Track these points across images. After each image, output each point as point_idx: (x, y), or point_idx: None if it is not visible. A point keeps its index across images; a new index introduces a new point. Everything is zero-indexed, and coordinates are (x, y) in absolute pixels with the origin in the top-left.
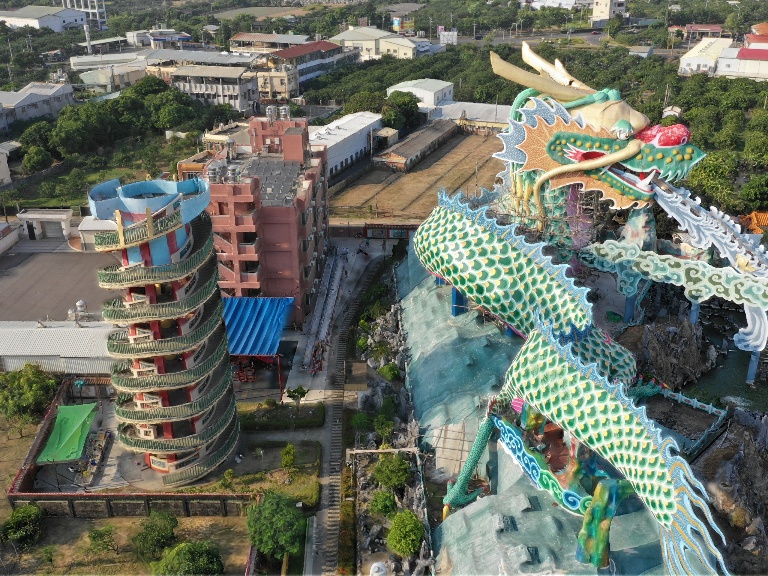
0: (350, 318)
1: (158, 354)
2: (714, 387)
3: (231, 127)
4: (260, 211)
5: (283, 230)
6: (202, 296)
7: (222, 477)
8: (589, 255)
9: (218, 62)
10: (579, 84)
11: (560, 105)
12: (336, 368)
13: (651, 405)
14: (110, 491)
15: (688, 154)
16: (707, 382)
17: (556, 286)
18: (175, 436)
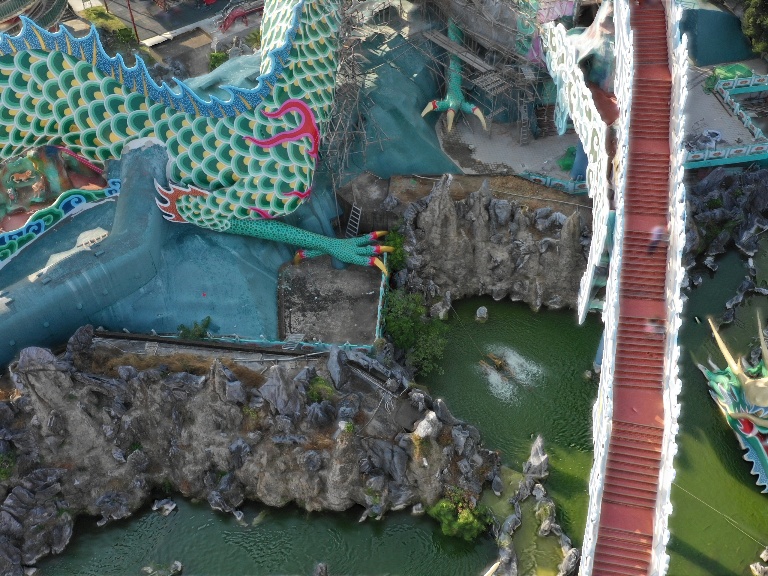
0: None
1: None
2: (557, 335)
3: None
4: None
5: None
6: None
7: None
8: (544, 38)
9: None
10: None
11: None
12: None
13: (347, 274)
14: None
15: None
16: (562, 323)
17: None
18: None
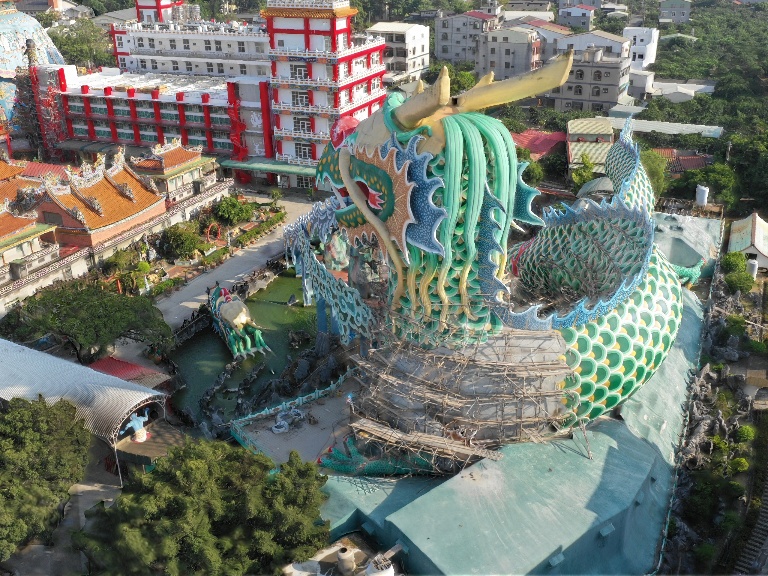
0: (759, 531)
1: None
2: None
3: None
4: None
5: None
6: None
7: None
8: None
9: None
10: None
11: None
12: None
13: None
14: None
15: None
16: None
17: None
18: None
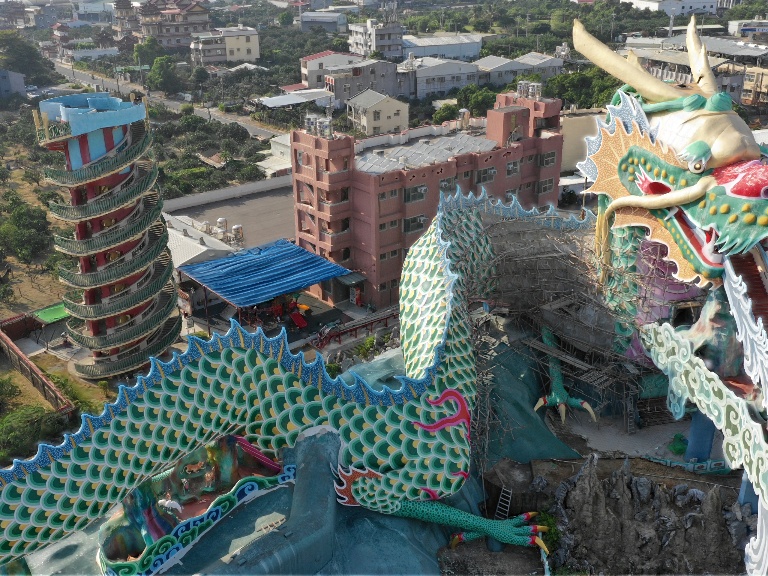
0: None
1: (61, 250)
2: None
3: (591, 112)
4: (351, 173)
5: (367, 199)
6: (96, 210)
7: (111, 387)
8: (647, 337)
9: (725, 52)
10: (704, 82)
11: (639, 106)
12: (334, 354)
13: (505, 556)
14: (54, 358)
15: (765, 216)
16: None
17: (439, 334)
18: (97, 334)
